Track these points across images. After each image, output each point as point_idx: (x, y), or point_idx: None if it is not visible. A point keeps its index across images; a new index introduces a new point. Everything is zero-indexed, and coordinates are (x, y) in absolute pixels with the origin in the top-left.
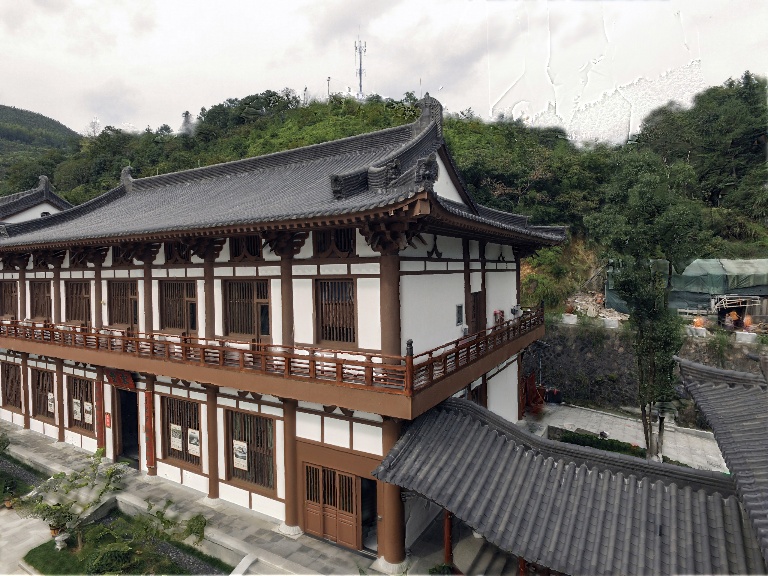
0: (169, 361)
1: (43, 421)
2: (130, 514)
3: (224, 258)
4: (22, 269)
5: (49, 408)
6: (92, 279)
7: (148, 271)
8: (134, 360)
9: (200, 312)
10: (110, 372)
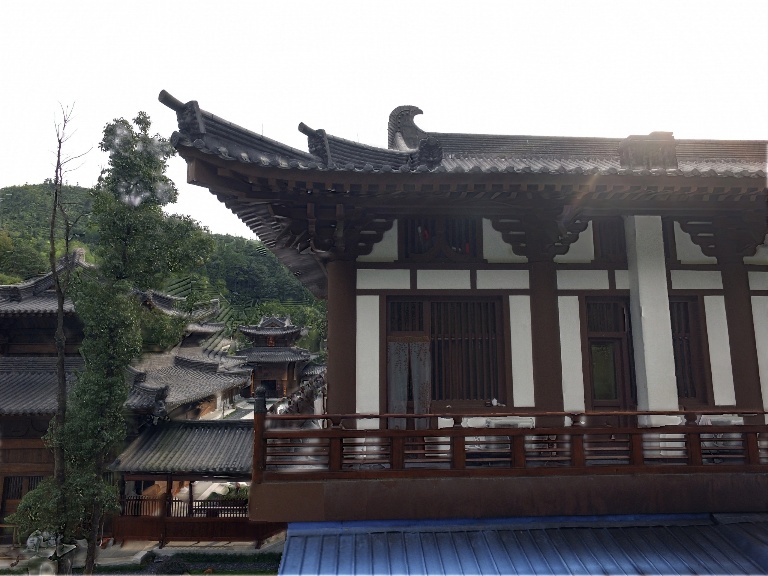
0: None
1: None
2: None
3: None
4: None
5: None
6: None
7: None
8: None
9: None
10: None
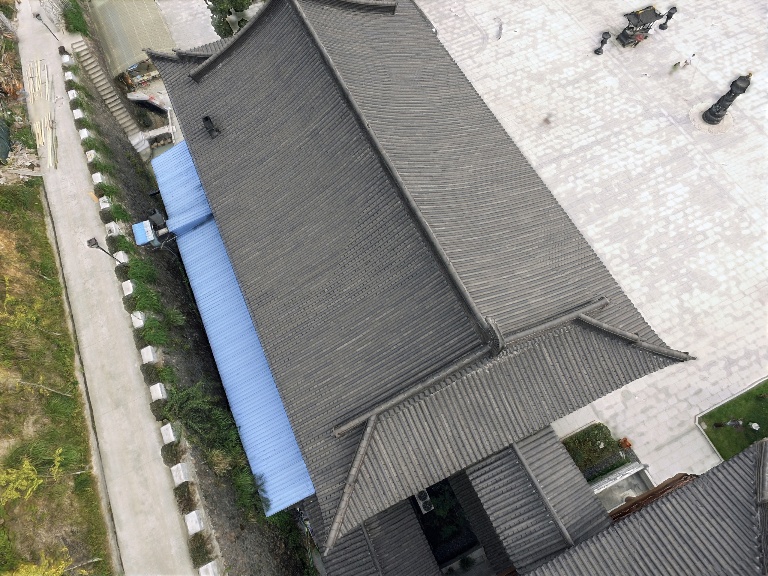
0: None
1: None
2: None
3: None
4: None
5: None
6: None
7: None
8: None
9: None
10: None
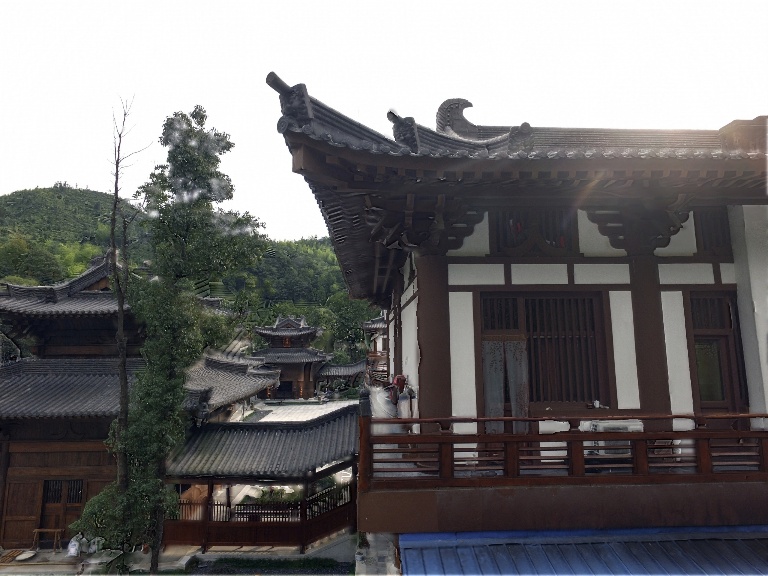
0: None
1: None
2: None
3: None
4: None
5: None
6: None
7: None
8: None
9: None
10: None
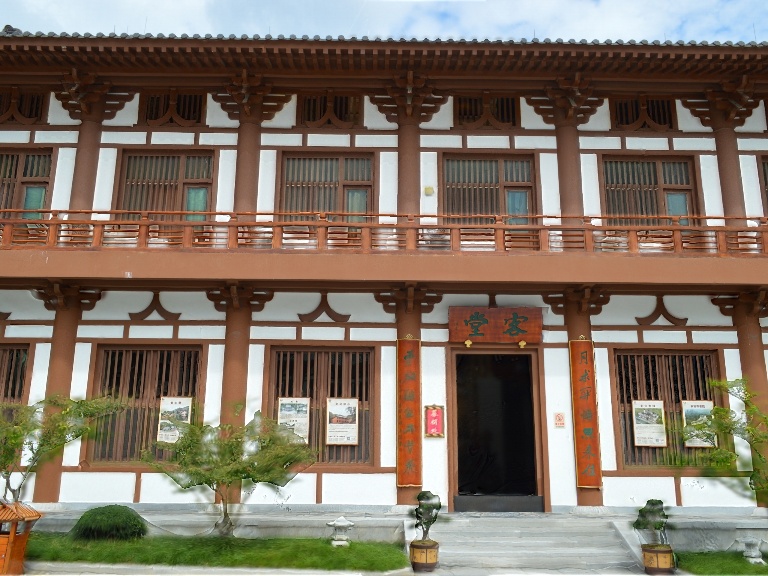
0: (731, 256)
1: (135, 470)
2: (679, 548)
3: (755, 127)
4: (95, 122)
5: (162, 435)
6: (386, 149)
7: (574, 138)
8: (633, 262)
9: (709, 203)
10: (472, 313)
